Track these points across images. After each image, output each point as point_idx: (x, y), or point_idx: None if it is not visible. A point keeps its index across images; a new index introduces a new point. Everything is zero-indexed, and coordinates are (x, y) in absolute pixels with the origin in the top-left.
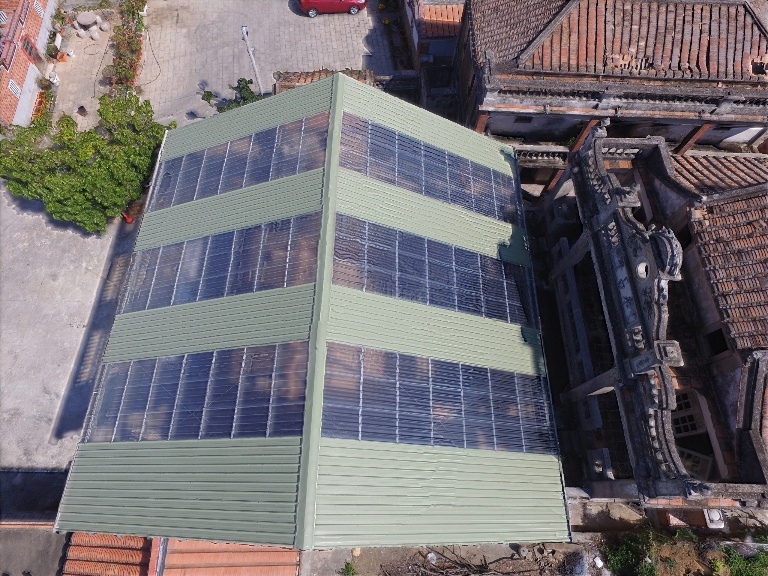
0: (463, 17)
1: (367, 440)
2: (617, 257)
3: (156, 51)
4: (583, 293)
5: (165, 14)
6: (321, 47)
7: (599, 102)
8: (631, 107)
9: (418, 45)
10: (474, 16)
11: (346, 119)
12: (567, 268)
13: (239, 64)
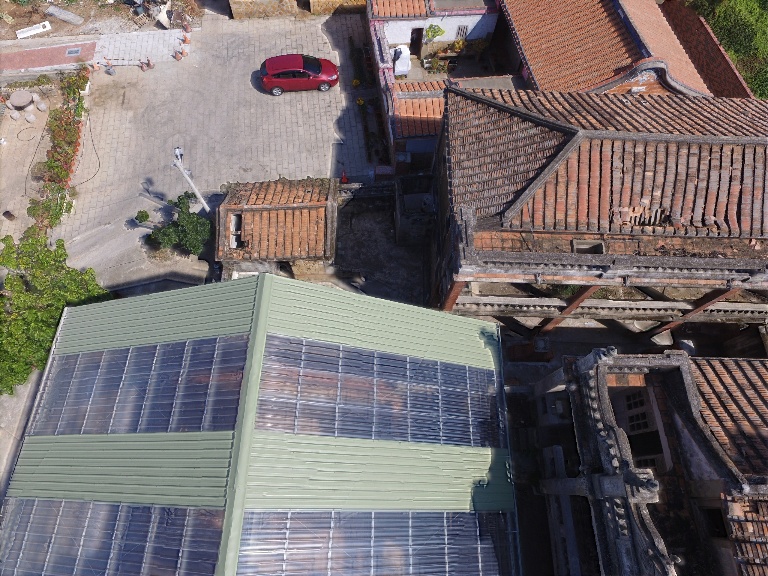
0: (442, 126)
1: None
2: (626, 559)
3: (96, 140)
4: (581, 516)
5: (110, 93)
6: (285, 133)
7: (603, 272)
8: (643, 276)
9: (393, 142)
10: (452, 143)
11: (270, 347)
12: (561, 495)
13: (190, 156)
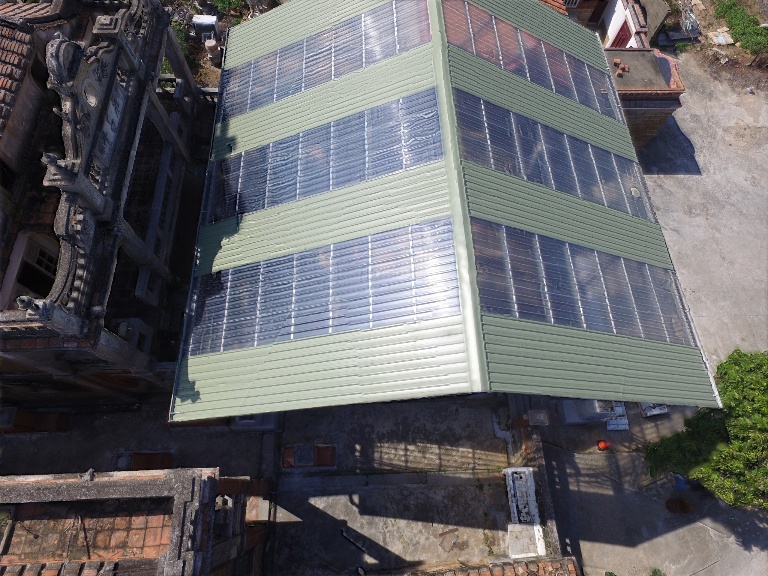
0: None
1: (388, 3)
2: (105, 149)
3: None
4: None
5: None
6: None
7: None
8: None
9: None
10: None
11: (453, 298)
12: None
13: None
